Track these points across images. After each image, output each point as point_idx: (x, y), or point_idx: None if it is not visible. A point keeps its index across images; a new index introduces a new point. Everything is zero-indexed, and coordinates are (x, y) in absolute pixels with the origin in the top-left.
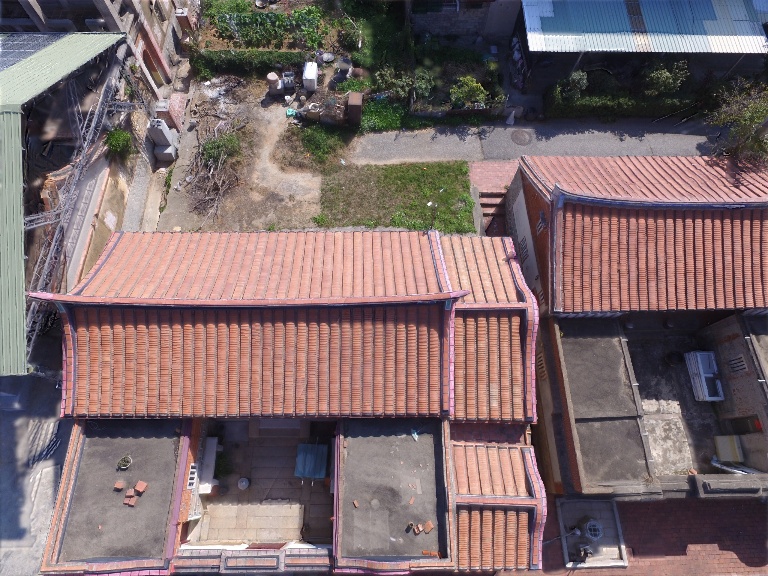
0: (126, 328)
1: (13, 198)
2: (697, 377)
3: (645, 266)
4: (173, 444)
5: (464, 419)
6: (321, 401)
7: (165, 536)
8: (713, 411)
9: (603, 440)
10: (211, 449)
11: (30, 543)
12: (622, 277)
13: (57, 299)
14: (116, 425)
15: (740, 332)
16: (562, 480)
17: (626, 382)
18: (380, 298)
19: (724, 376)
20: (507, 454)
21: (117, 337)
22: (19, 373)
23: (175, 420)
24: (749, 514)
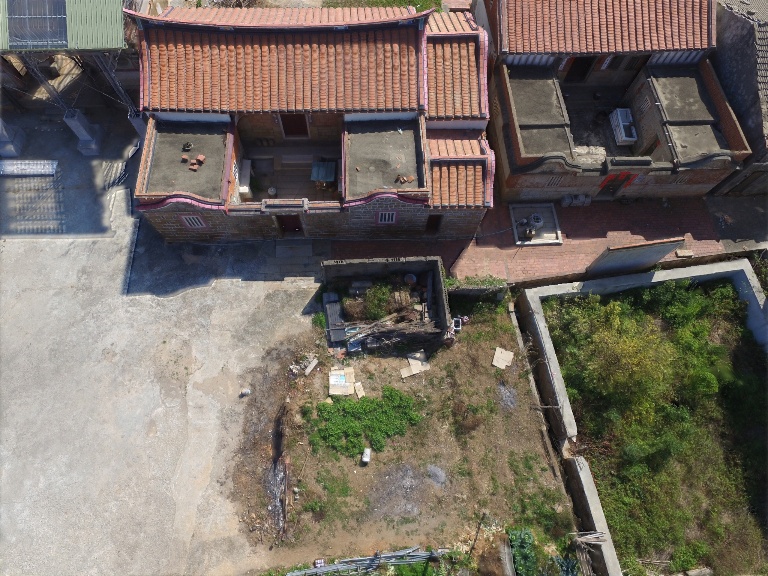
0: (186, 47)
1: None
2: (617, 126)
3: (569, 20)
4: (222, 138)
5: (436, 117)
6: (330, 100)
7: (221, 186)
8: (630, 152)
9: (539, 139)
10: (247, 166)
11: (112, 235)
12: (552, 27)
13: (138, 15)
14: (179, 126)
15: (645, 79)
16: (509, 164)
17: (557, 105)
18: (372, 20)
19: (637, 121)
20: (468, 142)
21: (180, 53)
22: (119, 47)
23: (222, 125)
24: (655, 214)
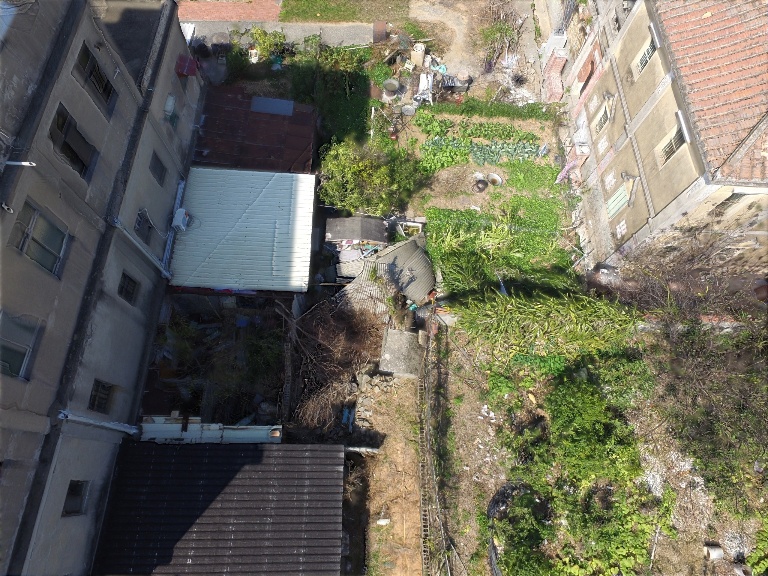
0: None
1: None
2: None
3: None
4: None
5: None
6: None
7: None
8: None
9: None
10: None
11: None
12: None
13: None
14: None
15: None
16: None
17: None
18: None
19: None
20: None
21: None
22: None
23: None
24: None
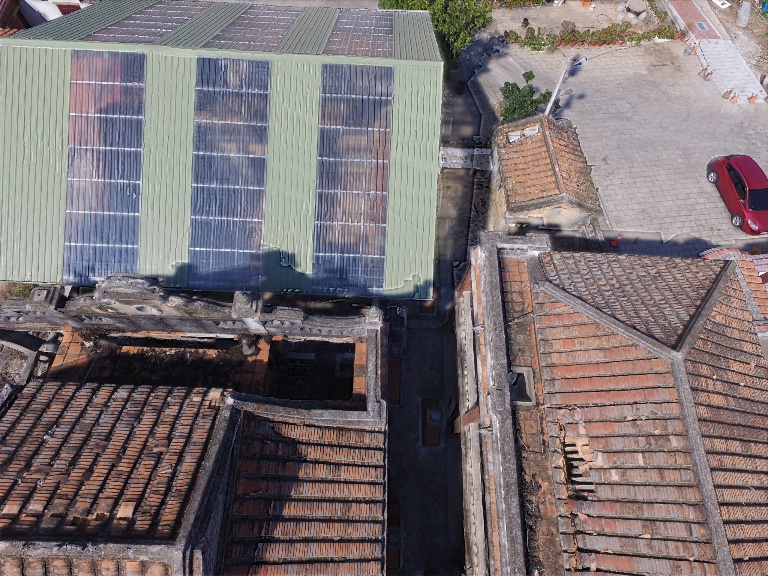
0: None
1: (55, 21)
2: None
3: None
4: None
5: None
6: None
7: None
8: None
9: None
10: None
11: None
12: None
13: None
14: None
15: None
16: None
17: None
18: None
19: None
20: None
21: None
22: None
23: None
24: None
